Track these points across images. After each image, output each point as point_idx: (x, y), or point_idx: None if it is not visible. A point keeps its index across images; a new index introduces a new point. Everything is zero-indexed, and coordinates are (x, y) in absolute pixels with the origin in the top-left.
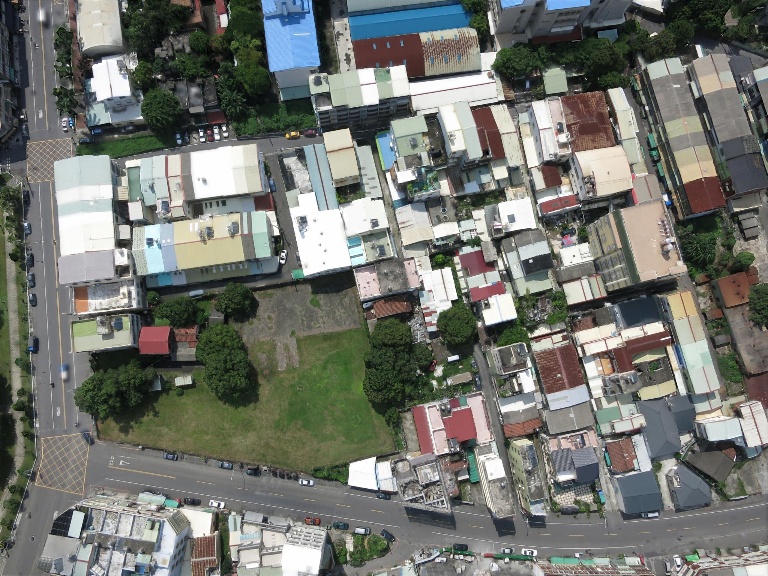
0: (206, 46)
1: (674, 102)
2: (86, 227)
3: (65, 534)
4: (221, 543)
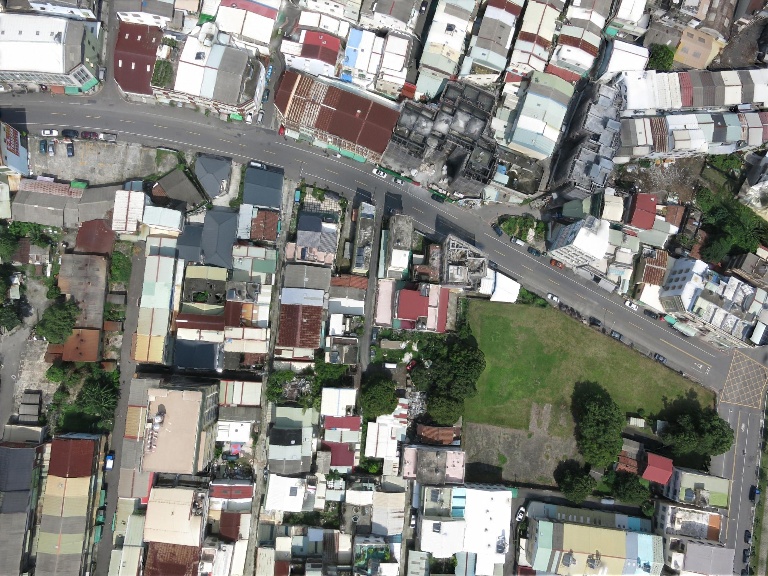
0: None
1: (60, 575)
2: None
3: (767, 328)
4: (636, 273)
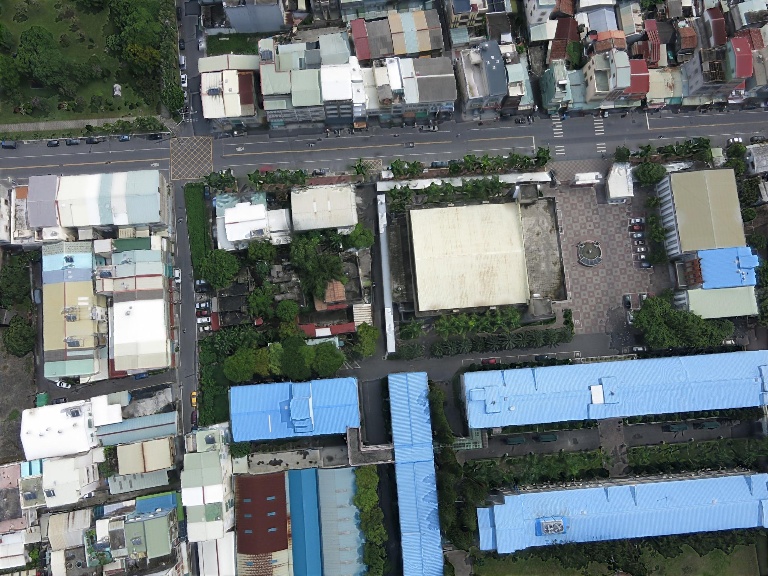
0: (280, 317)
1: None
2: (83, 201)
3: None
4: None
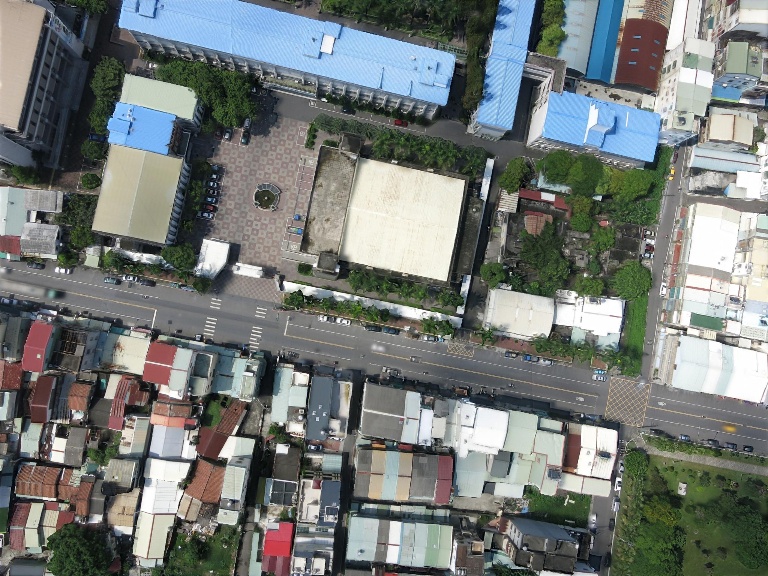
0: None
1: None
2: (746, 372)
3: None
4: None
